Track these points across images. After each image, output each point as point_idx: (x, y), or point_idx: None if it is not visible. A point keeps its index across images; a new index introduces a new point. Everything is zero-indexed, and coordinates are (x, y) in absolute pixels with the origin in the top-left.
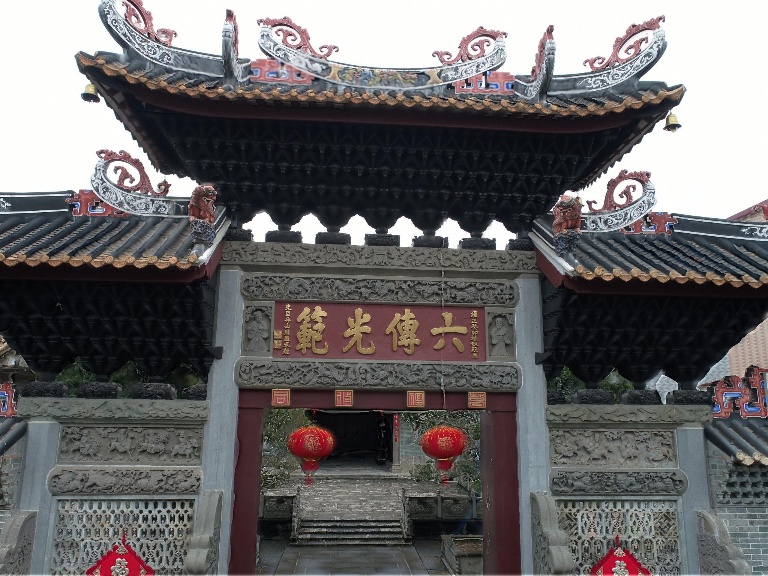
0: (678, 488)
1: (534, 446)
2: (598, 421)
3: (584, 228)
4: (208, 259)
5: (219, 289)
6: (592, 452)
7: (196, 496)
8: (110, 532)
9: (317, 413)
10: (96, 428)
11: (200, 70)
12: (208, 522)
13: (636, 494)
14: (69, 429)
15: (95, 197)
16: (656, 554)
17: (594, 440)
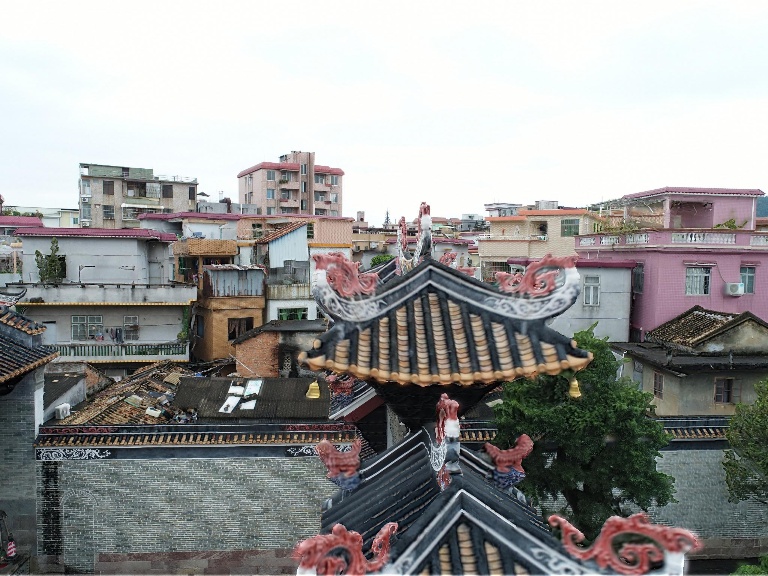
0: None
1: None
2: None
3: (430, 455)
4: (348, 412)
5: (387, 421)
6: None
7: None
8: None
9: None
10: None
11: None
12: None
13: None
14: None
15: None
16: None
17: None
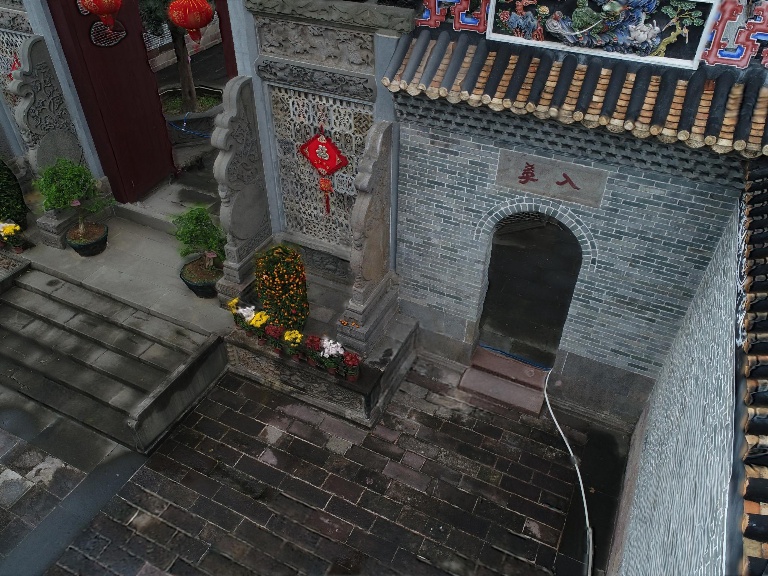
0: (369, 95)
1: (237, 33)
2: (292, 14)
3: None
4: None
5: None
6: (295, 45)
7: None
8: (8, 52)
9: None
10: None
11: None
12: (25, 61)
13: (333, 93)
14: None
15: None
16: (354, 147)
17: (298, 33)
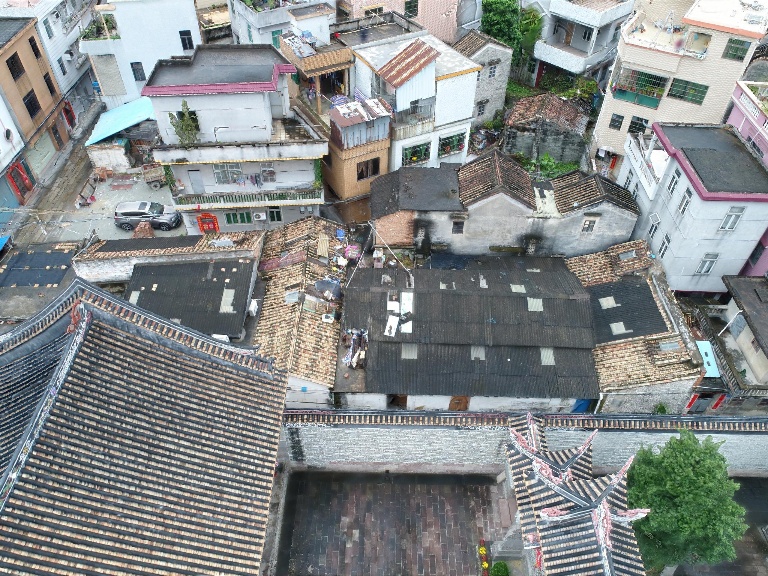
0: None
1: None
2: None
3: None
4: None
5: None
6: None
7: None
8: None
9: None
10: None
11: (568, 497)
12: None
13: None
14: None
15: None
16: None
17: None
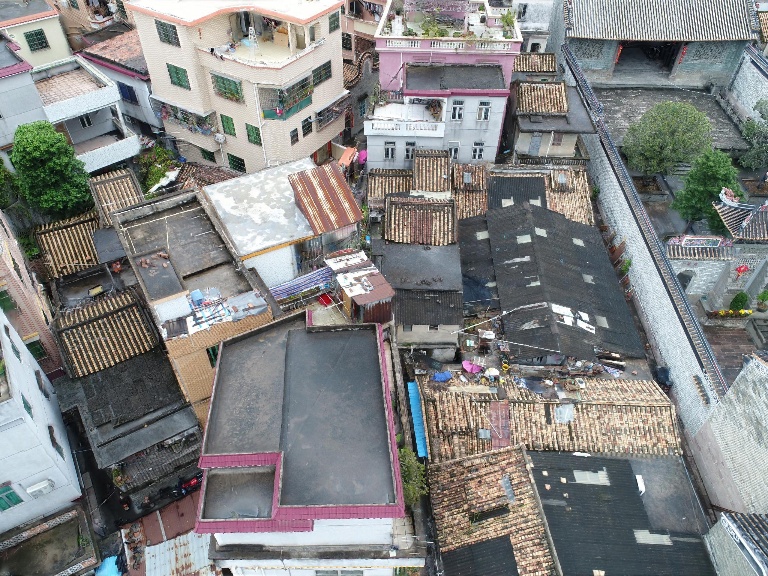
0: None
1: None
2: None
3: None
4: None
5: None
6: None
7: (763, 259)
8: None
9: (631, 42)
10: (748, 248)
11: None
12: None
13: None
14: (742, 248)
15: (766, 207)
16: None
17: None
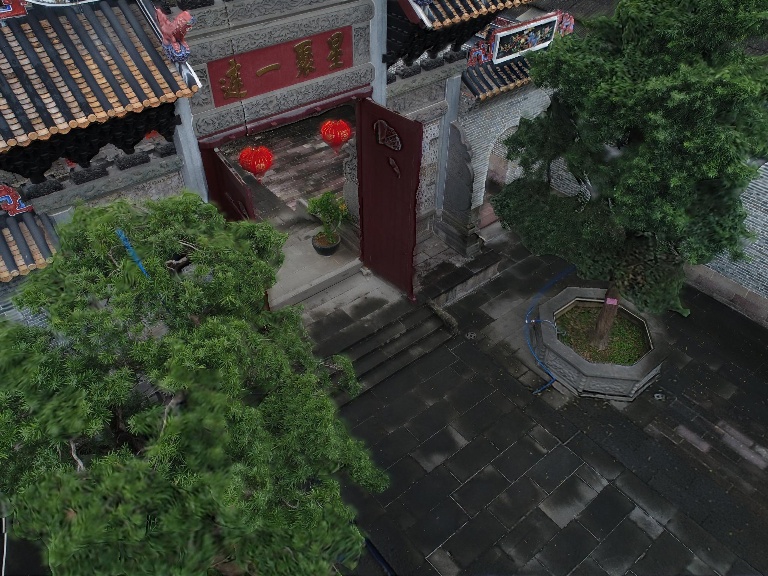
0: None
1: None
2: None
3: None
4: None
5: None
6: None
7: None
8: None
9: None
10: None
11: None
12: None
13: None
14: None
15: None
16: None
17: None
